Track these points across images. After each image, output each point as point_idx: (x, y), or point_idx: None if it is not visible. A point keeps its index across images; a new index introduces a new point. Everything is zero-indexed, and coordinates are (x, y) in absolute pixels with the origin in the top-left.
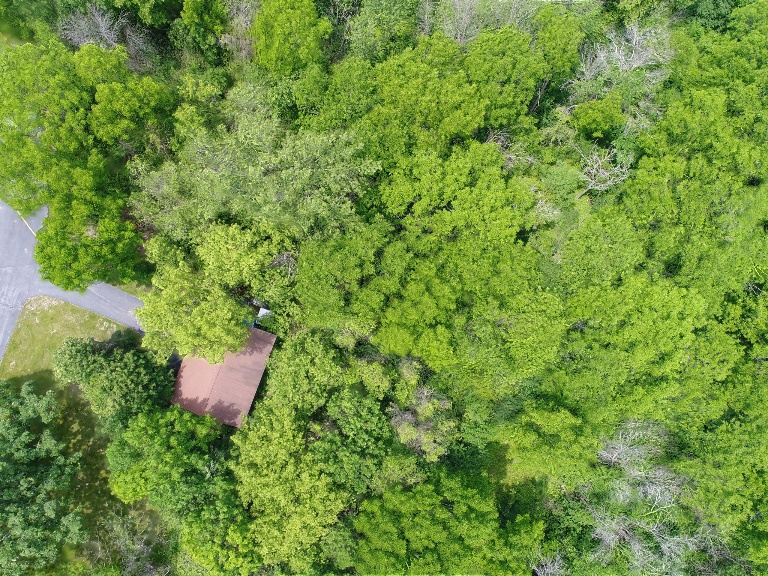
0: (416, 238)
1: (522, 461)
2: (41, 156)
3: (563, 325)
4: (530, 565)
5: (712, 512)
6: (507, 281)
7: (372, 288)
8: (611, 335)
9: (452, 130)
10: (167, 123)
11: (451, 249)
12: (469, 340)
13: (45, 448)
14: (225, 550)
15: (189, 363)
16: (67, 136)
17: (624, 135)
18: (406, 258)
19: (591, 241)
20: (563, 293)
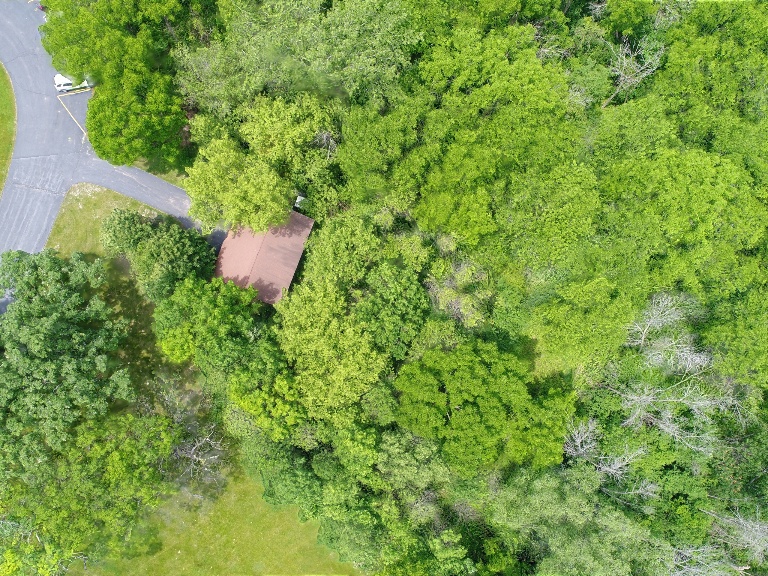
0: (456, 108)
1: (550, 355)
2: (95, 21)
3: (597, 198)
4: (566, 422)
5: (743, 372)
6: (544, 151)
7: (414, 152)
8: (645, 202)
9: (490, 8)
10: (210, 11)
11: (490, 118)
12: (508, 204)
13: (95, 309)
14: (272, 397)
15: (229, 245)
16: (118, 9)
17: (655, 26)
18: (447, 124)
19: (624, 120)
20: (597, 169)
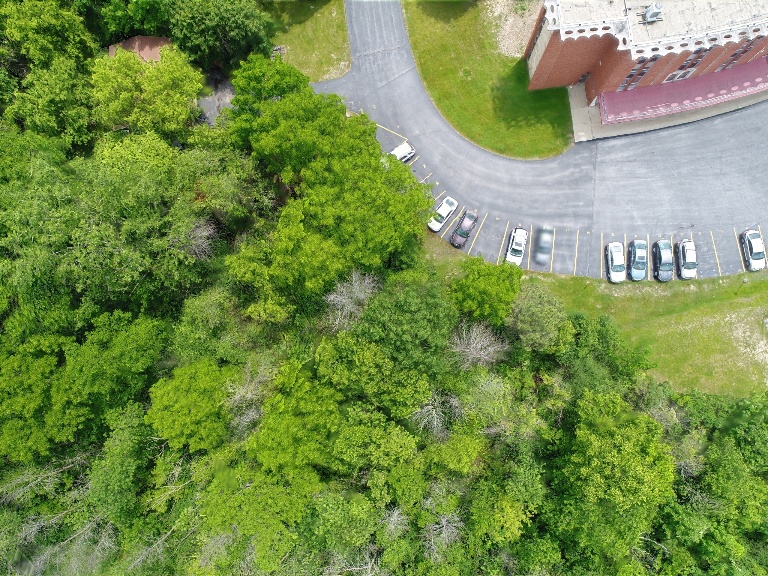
0: None
1: None
2: None
3: None
4: None
5: None
6: None
7: None
8: None
9: None
10: None
11: None
12: None
13: None
14: None
15: None
16: None
17: None
18: None
19: None
20: None
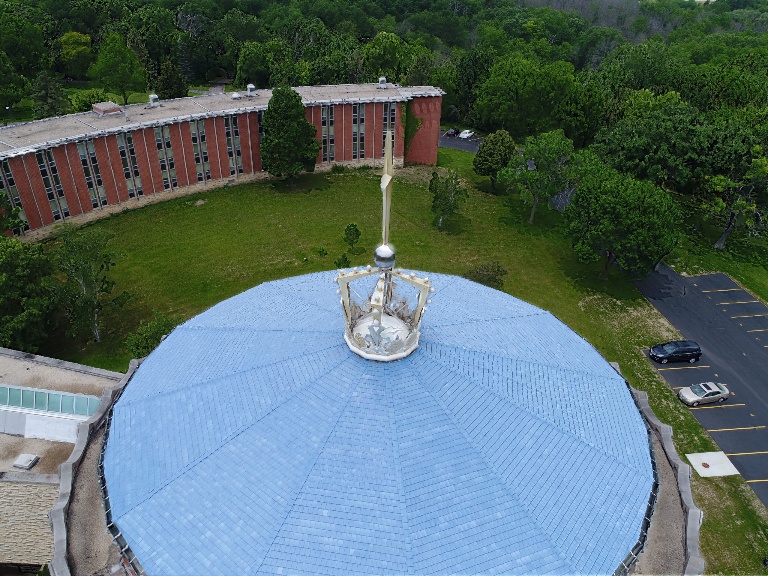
0: None
1: None
2: None
3: None
4: None
5: None
6: None
7: None
8: None
9: None
10: None
11: None
12: None
13: None
14: None
15: None
16: None
17: None
18: None
19: None
20: None
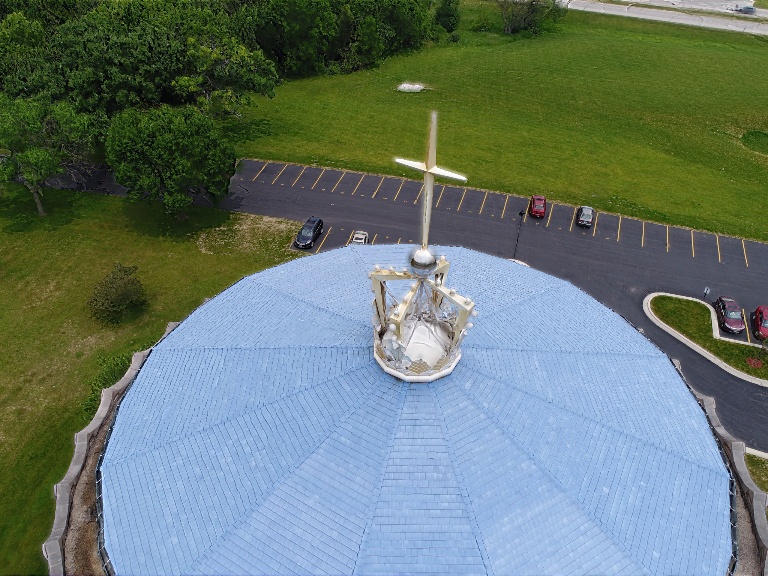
0: None
1: None
2: None
3: None
4: None
5: None
6: None
7: None
8: None
9: None
10: None
11: None
12: None
13: None
14: None
15: None
16: None
17: None
18: None
19: None
20: None
